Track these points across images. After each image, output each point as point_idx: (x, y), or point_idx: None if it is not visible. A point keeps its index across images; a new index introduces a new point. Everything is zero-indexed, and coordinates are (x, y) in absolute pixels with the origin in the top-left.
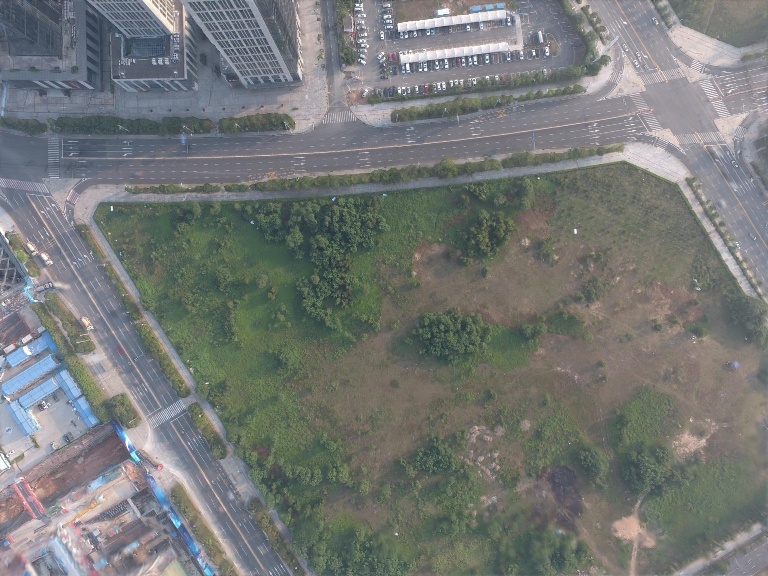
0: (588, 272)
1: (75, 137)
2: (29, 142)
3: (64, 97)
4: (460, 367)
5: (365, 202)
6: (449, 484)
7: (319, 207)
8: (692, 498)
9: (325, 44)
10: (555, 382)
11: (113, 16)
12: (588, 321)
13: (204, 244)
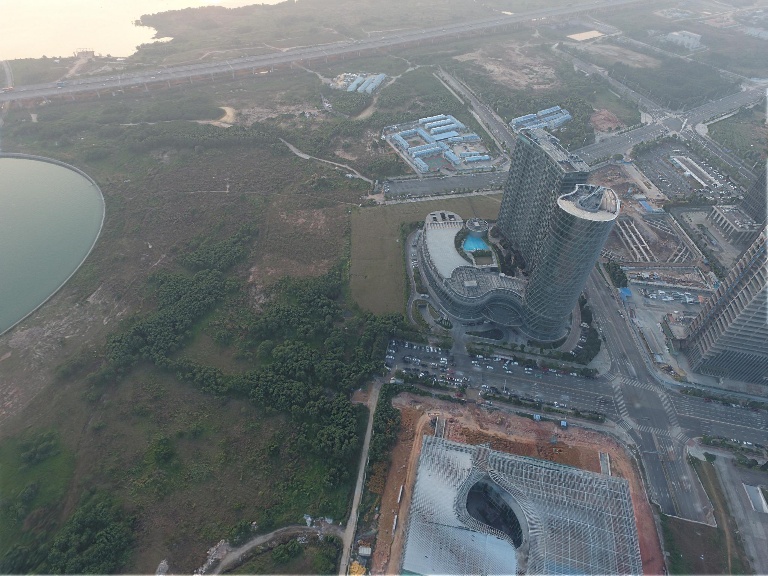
0: None
1: None
2: None
3: None
4: None
5: None
6: None
7: None
8: None
9: None
10: None
11: None
12: None
13: None
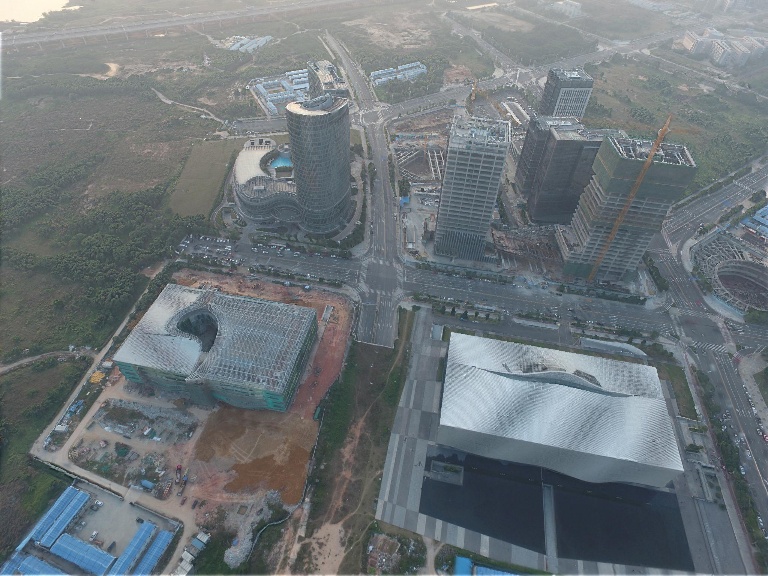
0: None
1: None
2: None
3: None
4: None
5: None
6: None
7: None
8: None
9: None
10: None
11: None
12: None
13: None
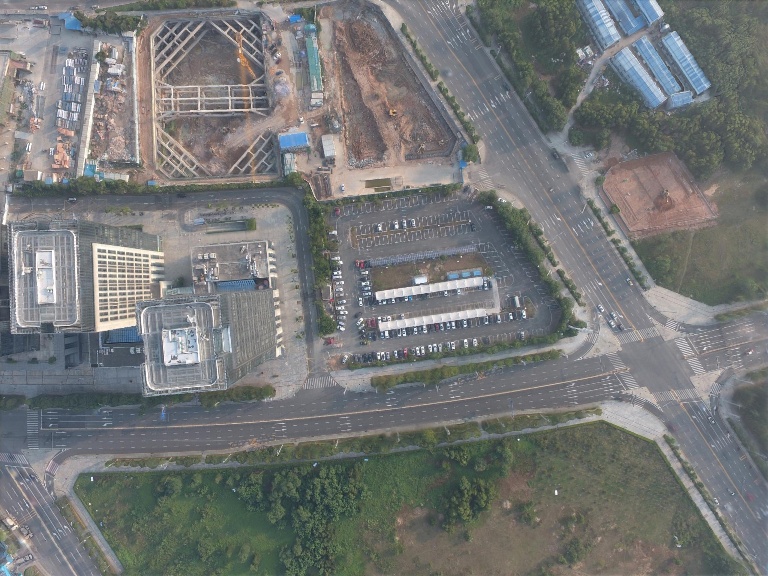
0: (570, 533)
1: (54, 408)
2: (8, 414)
3: None
4: None
5: (346, 470)
6: None
7: (300, 482)
8: None
9: (304, 311)
10: None
11: None
12: None
13: (186, 512)
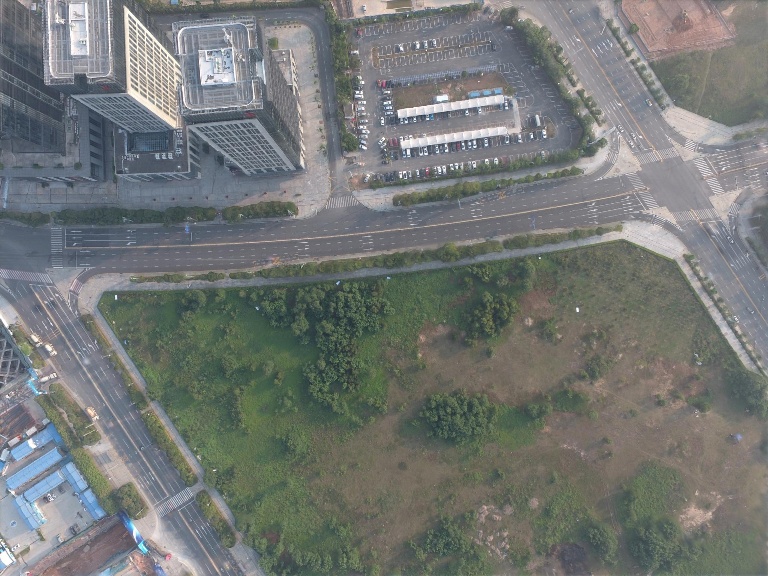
0: (591, 350)
1: (78, 227)
2: (32, 233)
3: (67, 188)
4: (467, 447)
5: (369, 286)
6: (460, 566)
7: (324, 294)
8: (700, 571)
9: (326, 130)
10: (562, 459)
11: (117, 118)
12: (592, 398)
13: (209, 331)
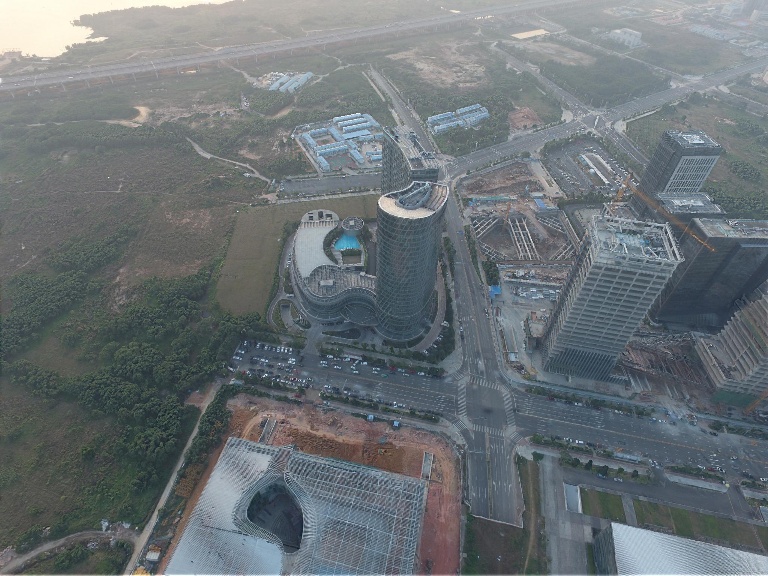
0: None
1: None
2: None
3: None
4: None
5: None
6: None
7: None
8: None
9: None
10: None
11: None
12: None
13: None
